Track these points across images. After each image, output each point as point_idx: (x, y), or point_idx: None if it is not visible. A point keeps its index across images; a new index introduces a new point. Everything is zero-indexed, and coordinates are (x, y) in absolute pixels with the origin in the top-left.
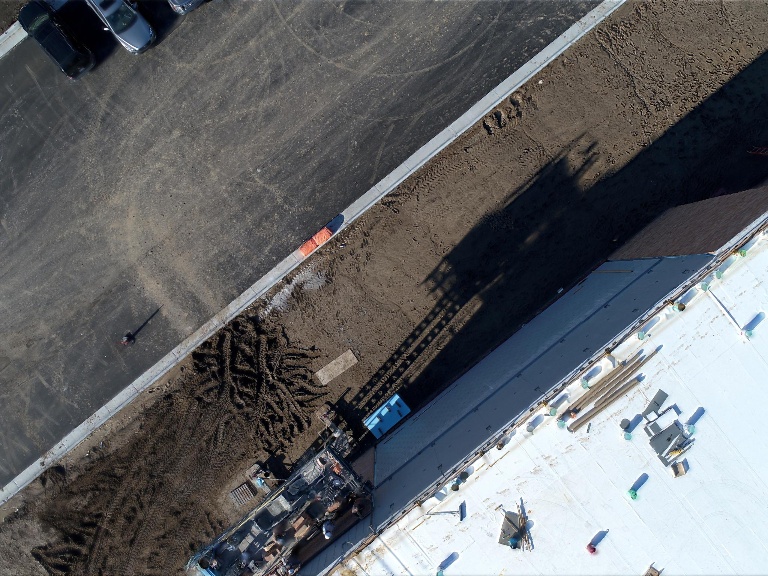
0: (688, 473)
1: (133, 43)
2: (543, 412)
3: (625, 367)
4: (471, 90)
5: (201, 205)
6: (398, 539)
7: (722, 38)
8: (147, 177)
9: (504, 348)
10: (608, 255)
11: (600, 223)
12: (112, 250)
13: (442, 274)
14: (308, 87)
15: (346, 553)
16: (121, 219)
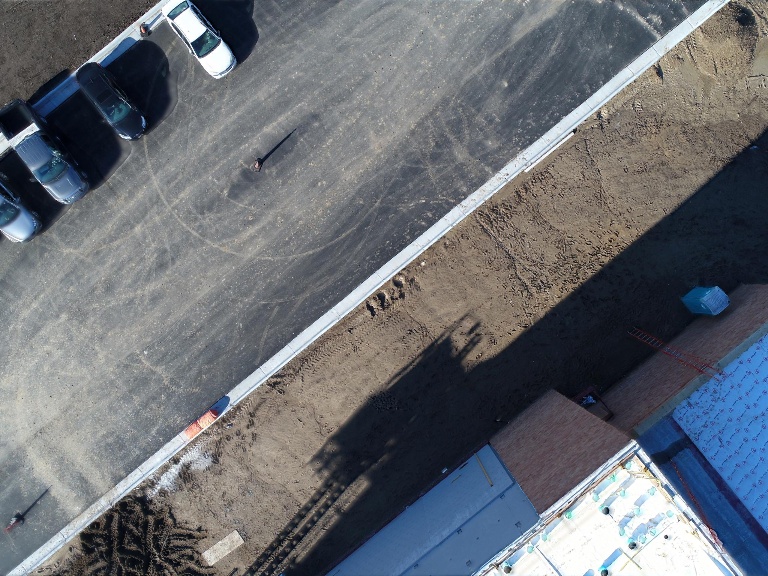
0: None
1: (17, 236)
2: None
3: None
4: (354, 272)
5: (89, 387)
6: None
7: (601, 220)
8: (35, 360)
9: (384, 535)
10: (491, 435)
11: (483, 403)
12: (1, 431)
13: (327, 454)
14: (193, 271)
15: None
16: (10, 401)
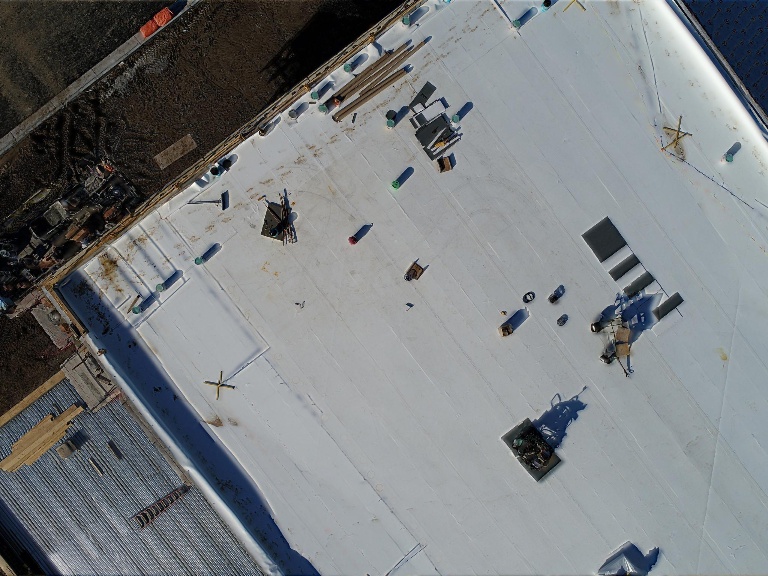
0: (455, 168)
1: None
2: (308, 100)
3: (392, 56)
4: None
5: None
6: (160, 229)
7: None
8: None
9: None
10: None
11: None
12: None
13: (285, 61)
14: None
15: (103, 236)
16: None
